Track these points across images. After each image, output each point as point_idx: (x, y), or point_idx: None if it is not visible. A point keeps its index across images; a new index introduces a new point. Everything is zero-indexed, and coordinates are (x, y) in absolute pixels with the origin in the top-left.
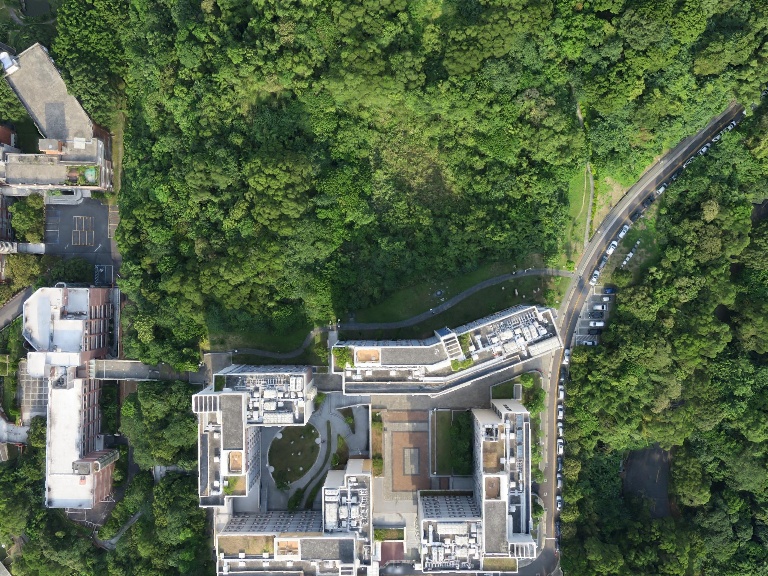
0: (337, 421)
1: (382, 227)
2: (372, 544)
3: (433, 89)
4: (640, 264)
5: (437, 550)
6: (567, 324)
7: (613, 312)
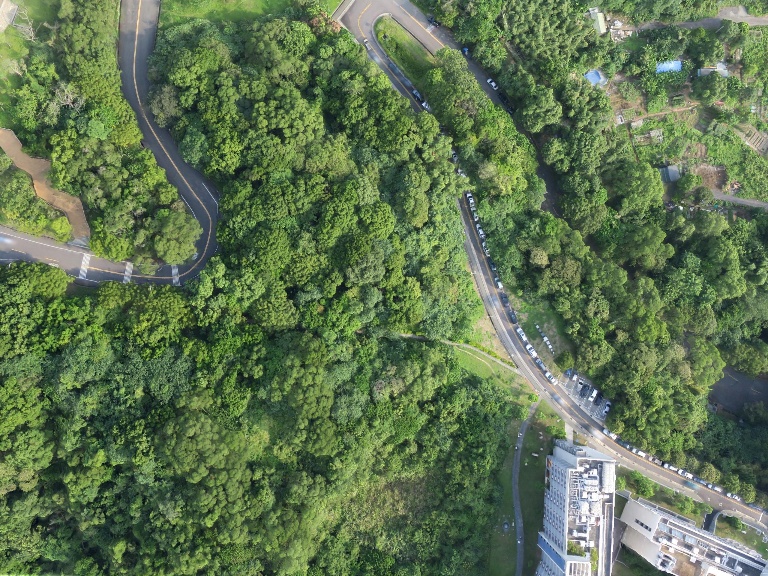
0: None
1: None
2: None
3: (335, 476)
4: (557, 333)
5: None
6: (581, 420)
7: (589, 377)
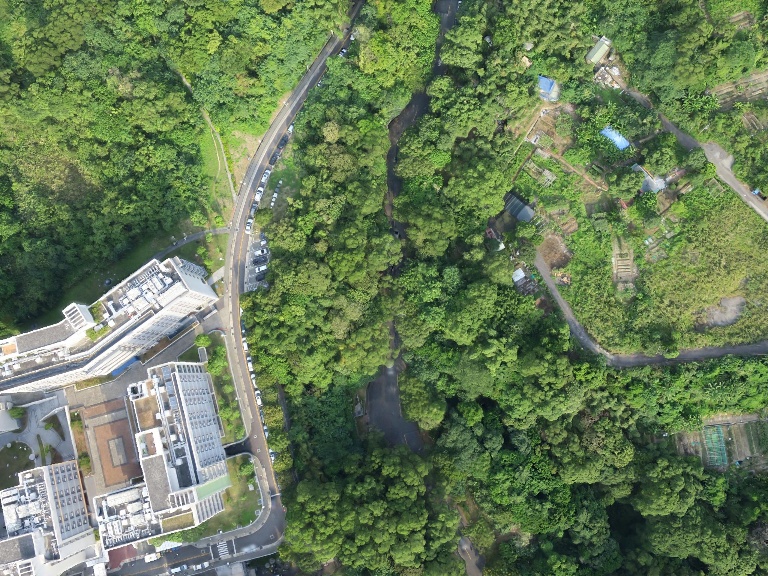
0: (46, 433)
1: (34, 234)
2: (57, 536)
3: (24, 94)
4: None
5: (111, 523)
6: (236, 277)
7: None
